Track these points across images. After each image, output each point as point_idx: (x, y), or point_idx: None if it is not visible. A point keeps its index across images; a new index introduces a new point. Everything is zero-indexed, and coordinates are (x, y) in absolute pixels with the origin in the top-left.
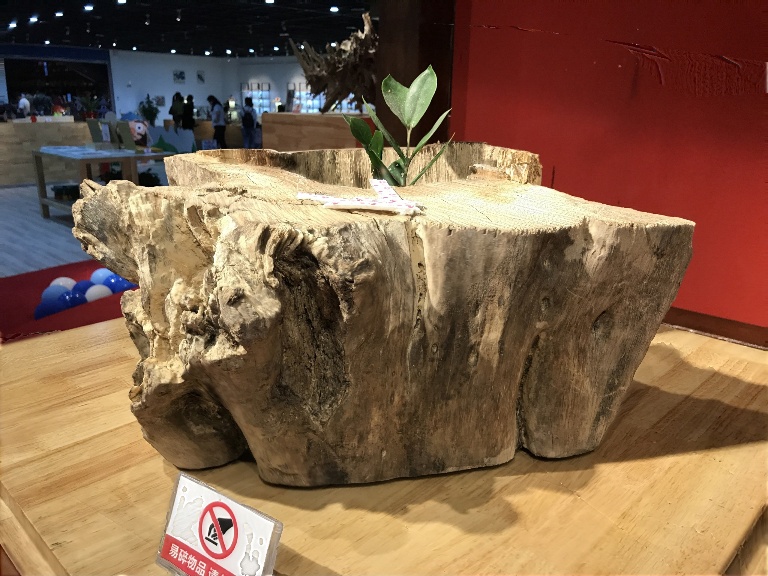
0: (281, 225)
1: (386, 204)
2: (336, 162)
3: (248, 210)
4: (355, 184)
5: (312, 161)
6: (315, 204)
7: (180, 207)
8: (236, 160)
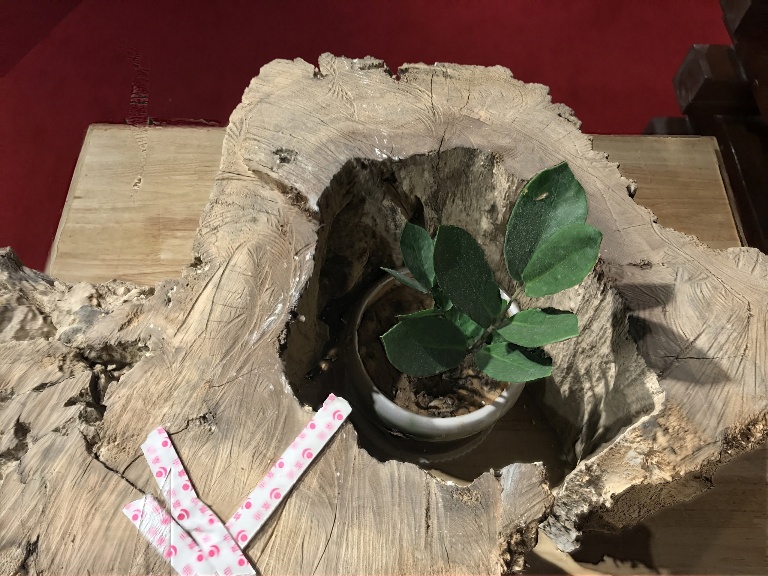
0: (8, 559)
1: (186, 562)
2: (493, 171)
3: (27, 481)
4: (508, 213)
5: (452, 159)
6: (135, 483)
7: (8, 398)
8: (272, 184)
